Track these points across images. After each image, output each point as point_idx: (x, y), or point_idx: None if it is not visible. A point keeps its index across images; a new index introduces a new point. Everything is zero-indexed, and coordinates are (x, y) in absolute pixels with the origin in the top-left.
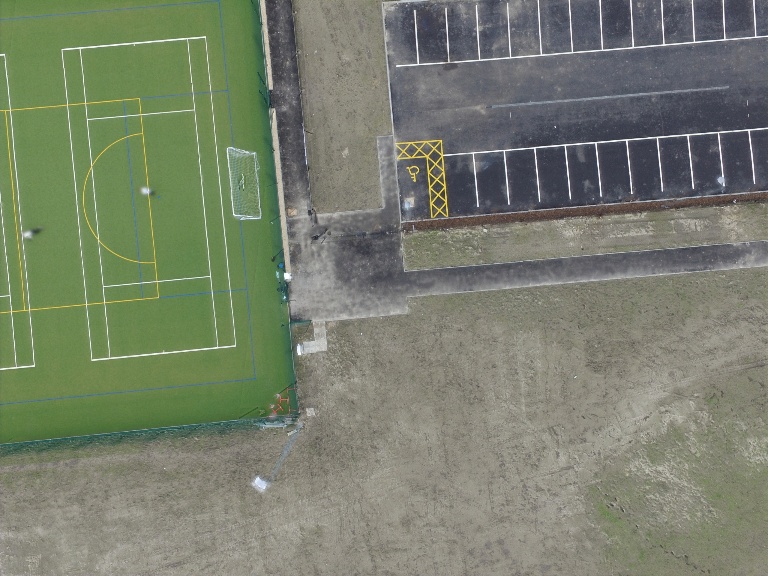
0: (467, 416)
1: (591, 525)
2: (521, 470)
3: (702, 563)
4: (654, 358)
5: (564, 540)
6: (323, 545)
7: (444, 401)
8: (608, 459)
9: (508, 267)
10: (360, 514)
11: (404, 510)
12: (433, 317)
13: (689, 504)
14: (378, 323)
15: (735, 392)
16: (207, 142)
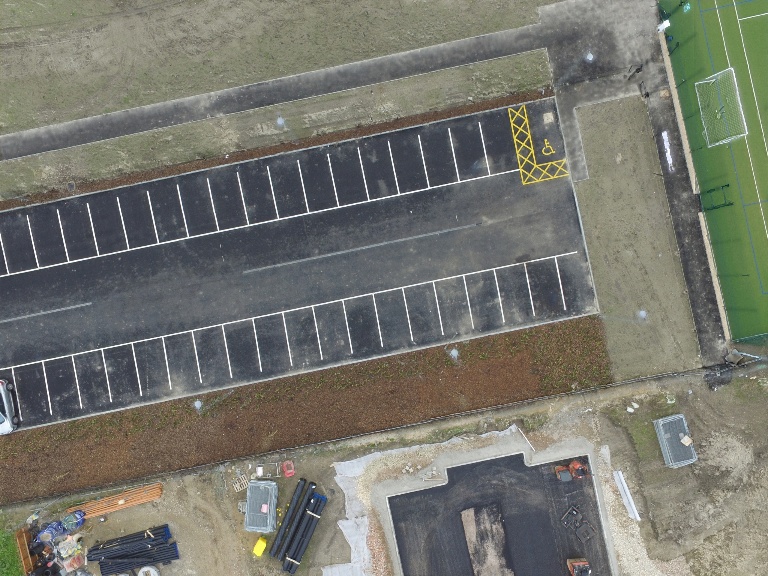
0: None
1: None
2: None
3: None
4: None
5: None
6: None
7: None
8: None
9: (444, 65)
10: None
11: None
12: (513, 6)
13: None
14: None
15: None
16: (758, 152)
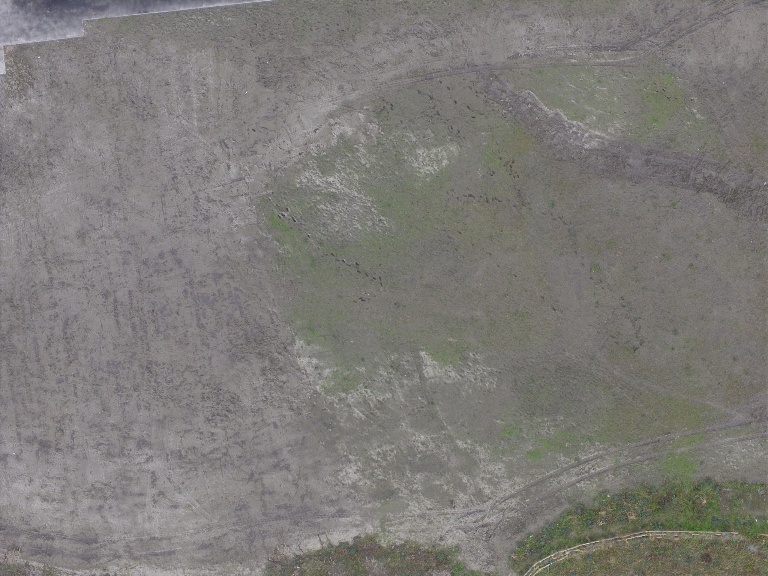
0: (140, 132)
1: (263, 235)
2: (193, 182)
3: (373, 270)
4: (324, 73)
5: (236, 249)
6: (1, 259)
7: (118, 118)
8: (279, 171)
9: None
10: (37, 228)
11: (79, 223)
12: (108, 39)
13: (360, 213)
14: (55, 46)
15: (404, 105)
16: None
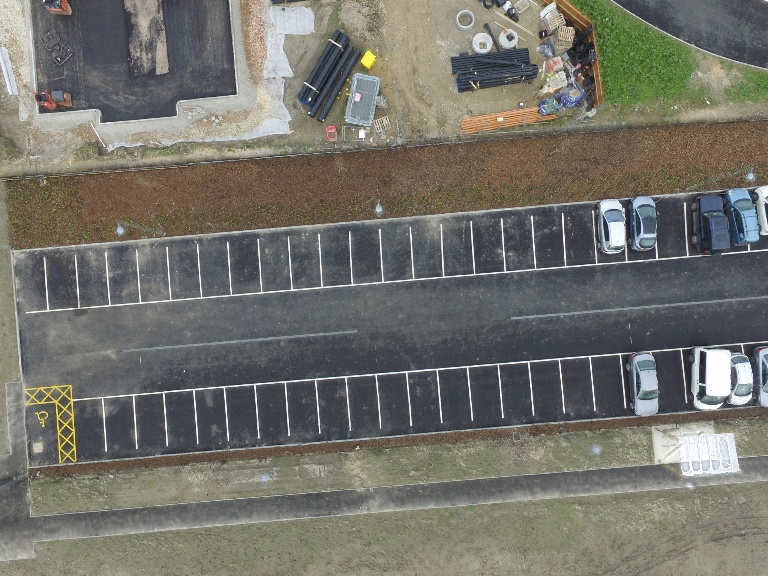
0: None
1: None
2: None
3: None
4: None
5: None
6: None
7: None
8: None
9: (133, 512)
10: None
11: None
12: (58, 562)
13: None
14: (5, 567)
15: None
16: None
